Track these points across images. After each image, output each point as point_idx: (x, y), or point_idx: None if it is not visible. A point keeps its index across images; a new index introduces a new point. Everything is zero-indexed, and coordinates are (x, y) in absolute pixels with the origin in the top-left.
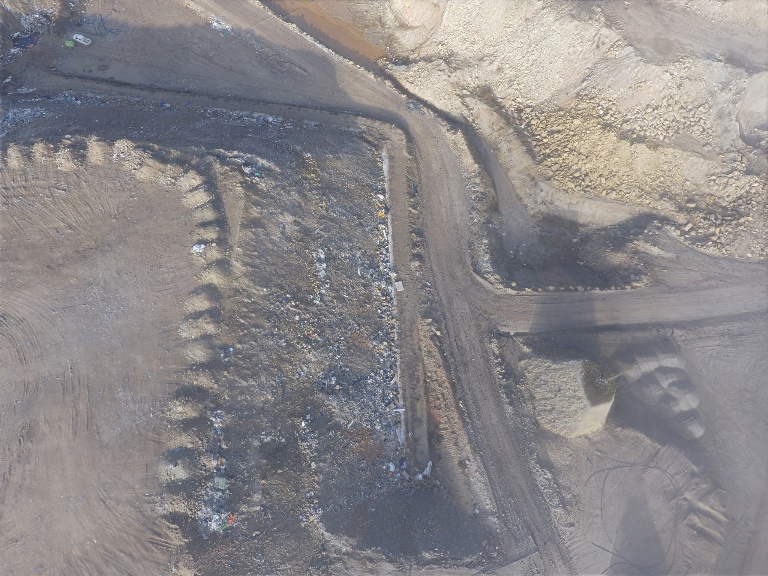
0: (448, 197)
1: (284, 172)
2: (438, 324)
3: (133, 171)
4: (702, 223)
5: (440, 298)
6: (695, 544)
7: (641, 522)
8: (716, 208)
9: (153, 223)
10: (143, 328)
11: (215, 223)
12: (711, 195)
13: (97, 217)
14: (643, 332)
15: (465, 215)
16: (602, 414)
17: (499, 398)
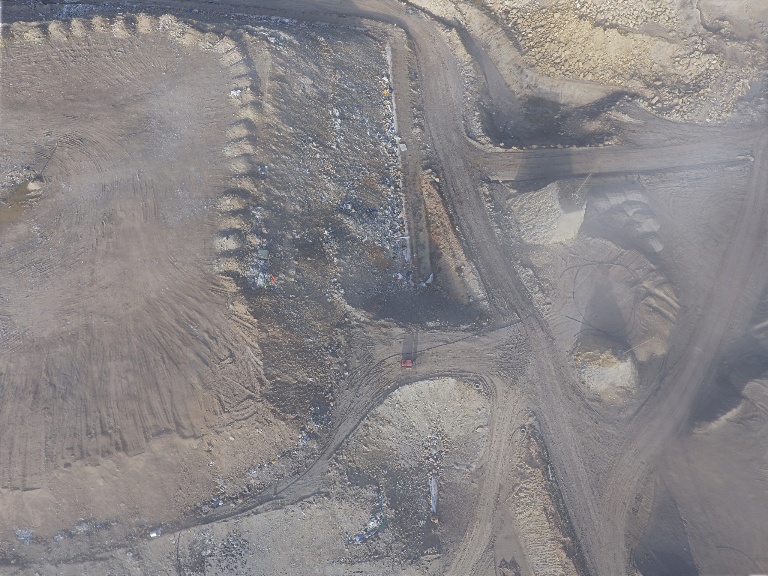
0: (444, 81)
1: (303, 47)
2: (437, 173)
3: (177, 38)
4: (667, 96)
5: (438, 156)
6: (651, 317)
7: (606, 302)
8: (680, 85)
9: (196, 76)
10: (194, 149)
11: (248, 75)
12: (676, 74)
13: (150, 71)
14: (613, 177)
15: (459, 95)
16: (574, 222)
17: (489, 224)
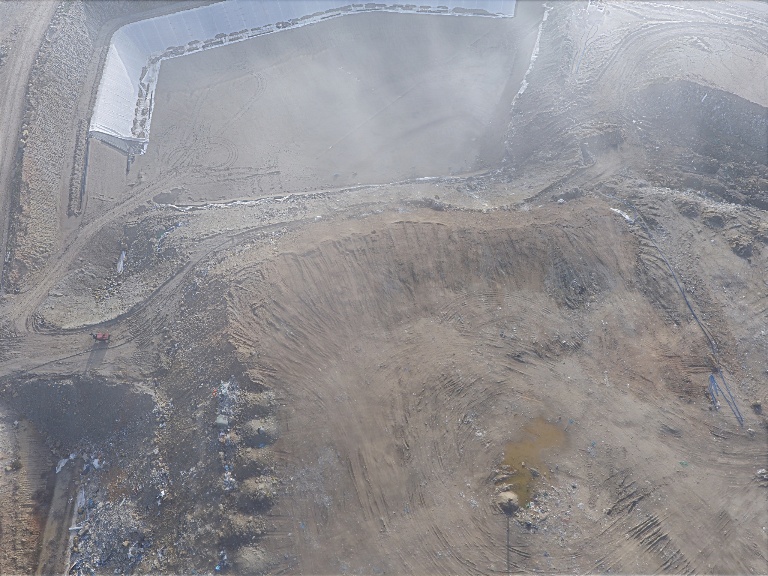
0: None
1: None
2: None
3: None
4: None
5: None
6: None
7: None
8: None
9: None
10: None
11: None
12: None
13: None
14: None
15: None
16: None
17: None
